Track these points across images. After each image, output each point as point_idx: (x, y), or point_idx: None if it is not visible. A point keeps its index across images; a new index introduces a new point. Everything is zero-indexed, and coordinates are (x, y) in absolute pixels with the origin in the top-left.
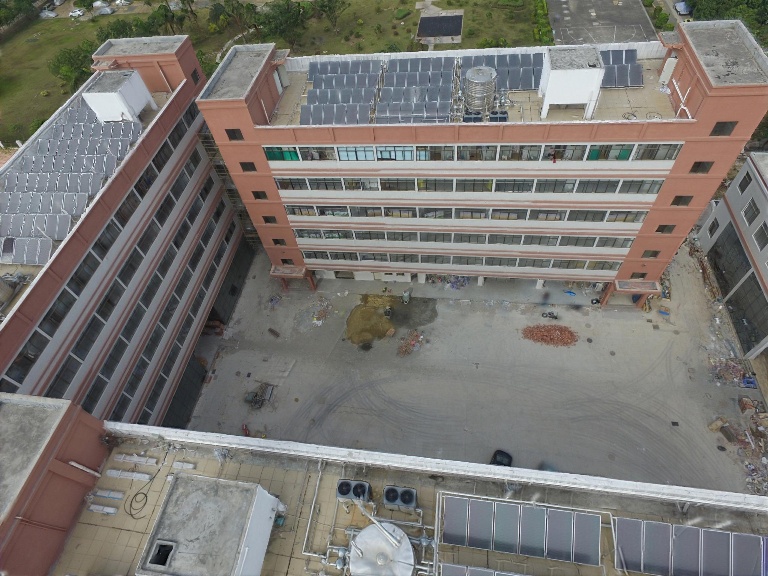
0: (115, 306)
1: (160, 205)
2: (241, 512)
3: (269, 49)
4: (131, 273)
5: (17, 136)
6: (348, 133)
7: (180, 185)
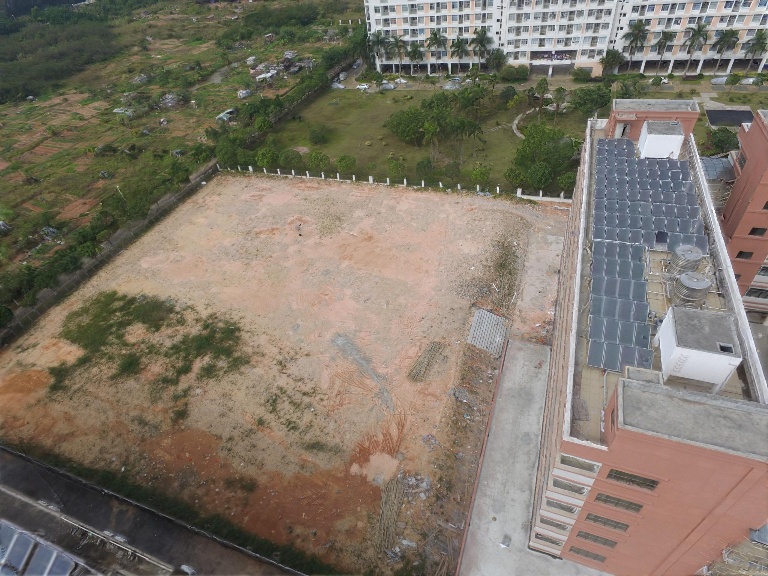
0: None
1: None
2: None
3: None
4: None
5: (359, 173)
6: None
7: None
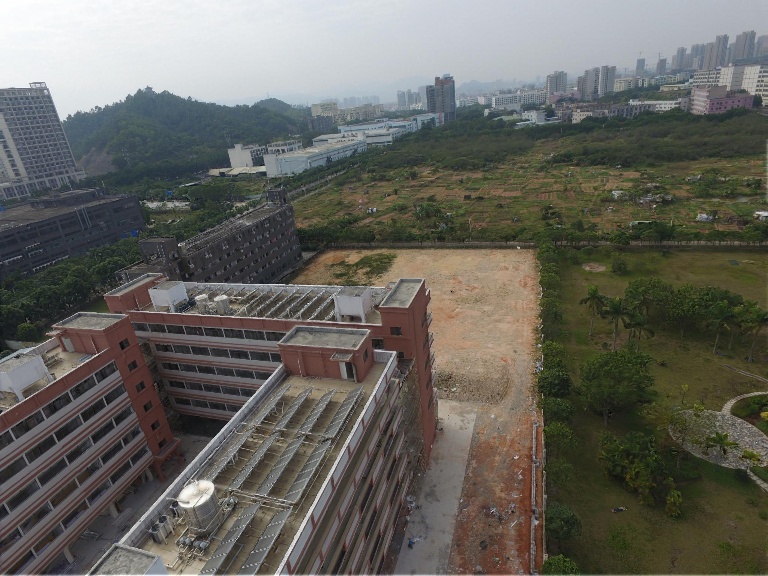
0: (240, 358)
1: None
2: None
3: None
4: (260, 359)
5: (561, 299)
6: None
7: None
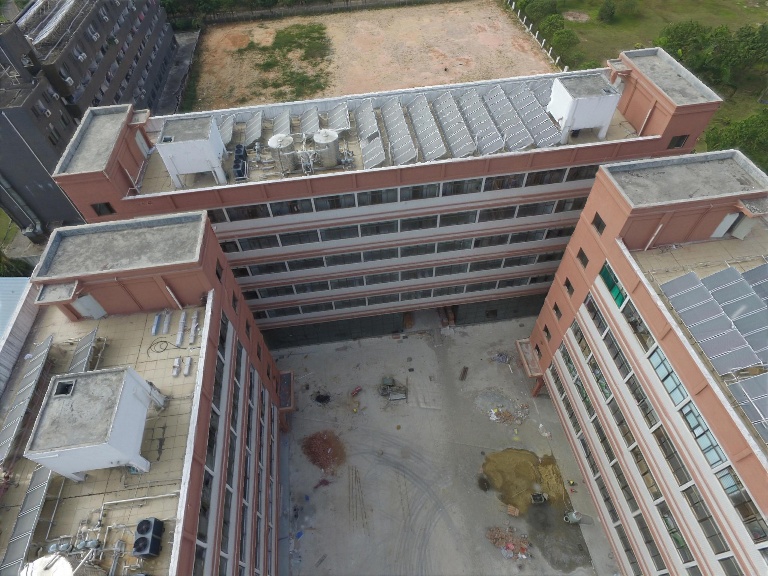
0: (379, 234)
1: (496, 207)
2: (88, 437)
3: (765, 188)
4: (415, 227)
5: None
6: (681, 352)
7: (537, 209)
